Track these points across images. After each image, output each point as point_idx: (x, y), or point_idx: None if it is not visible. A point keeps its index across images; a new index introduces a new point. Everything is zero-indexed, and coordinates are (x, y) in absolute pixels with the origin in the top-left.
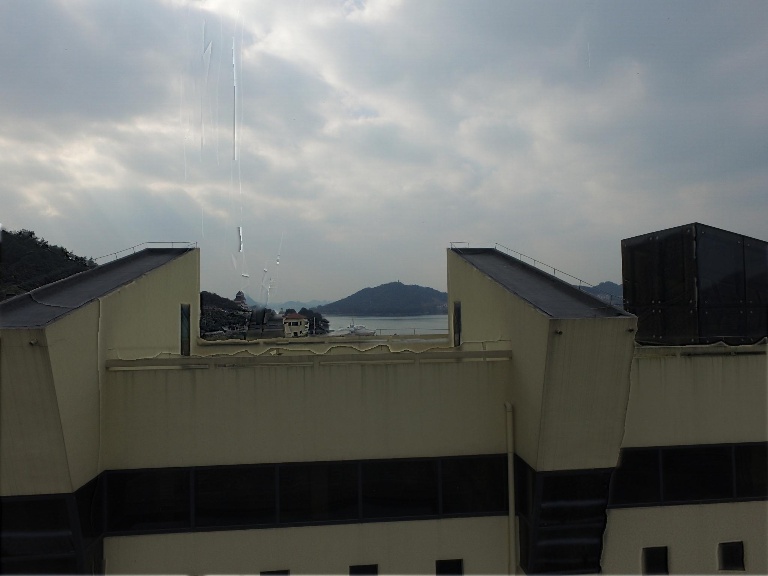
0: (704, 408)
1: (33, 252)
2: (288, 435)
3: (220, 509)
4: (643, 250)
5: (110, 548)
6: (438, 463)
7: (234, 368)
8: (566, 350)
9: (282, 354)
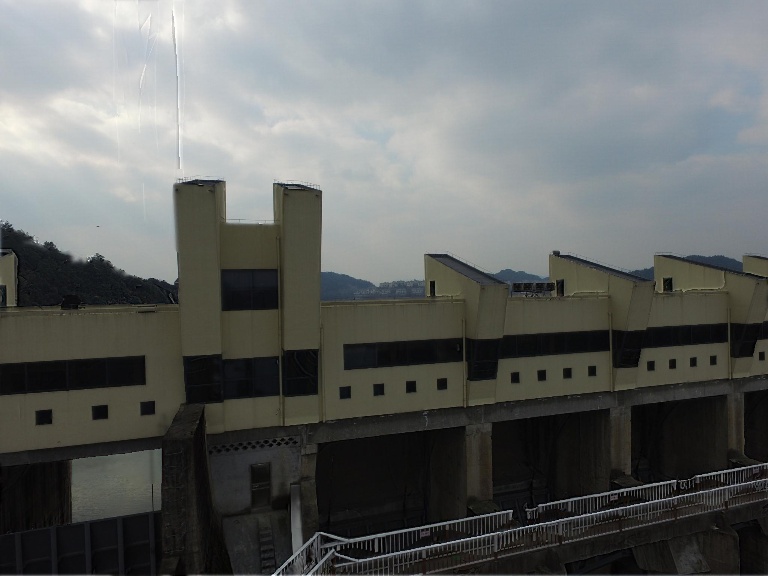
0: None
1: (8, 236)
2: None
3: (767, 333)
4: None
5: None
6: None
7: None
8: None
9: None
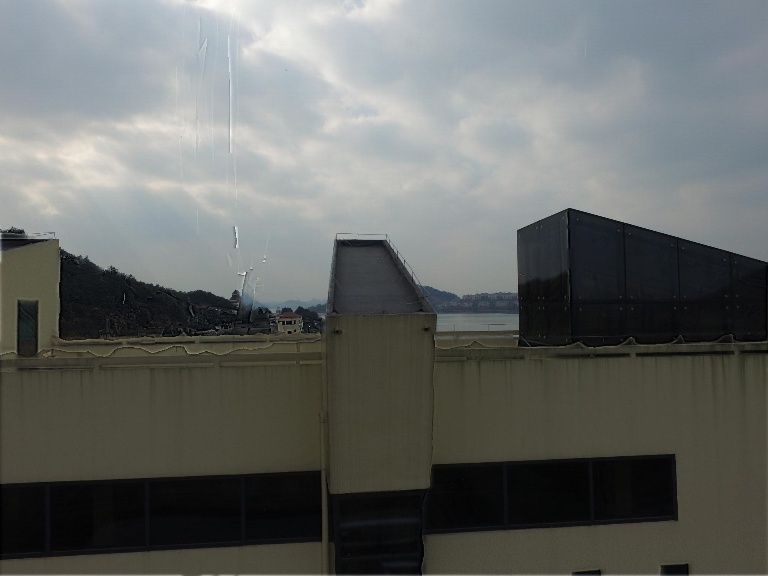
0: (557, 418)
1: None
2: (64, 450)
3: None
4: (533, 241)
5: None
6: (241, 482)
7: None
8: (350, 352)
9: (56, 356)
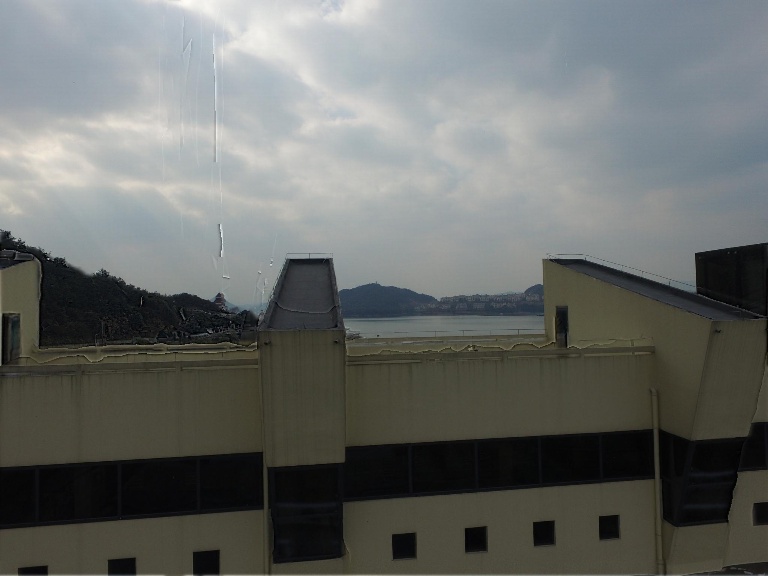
0: None
1: None
2: (482, 417)
3: (431, 478)
4: (719, 262)
5: (347, 511)
6: (599, 438)
7: (441, 362)
8: (721, 345)
9: (478, 350)
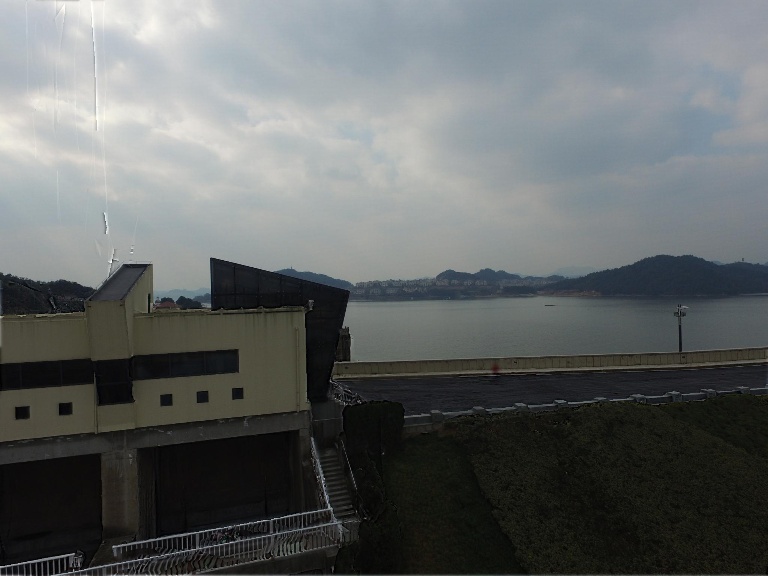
0: (192, 337)
1: None
2: None
3: None
4: None
5: None
6: (60, 363)
7: None
8: (95, 313)
9: None
